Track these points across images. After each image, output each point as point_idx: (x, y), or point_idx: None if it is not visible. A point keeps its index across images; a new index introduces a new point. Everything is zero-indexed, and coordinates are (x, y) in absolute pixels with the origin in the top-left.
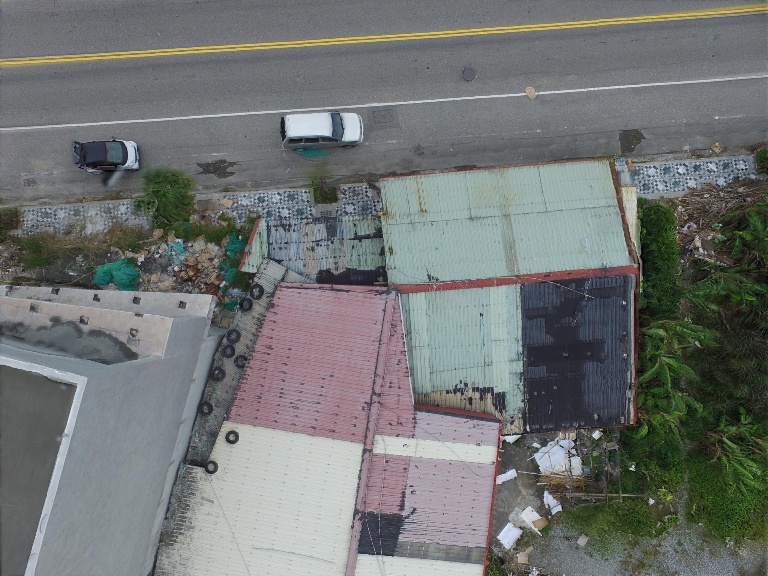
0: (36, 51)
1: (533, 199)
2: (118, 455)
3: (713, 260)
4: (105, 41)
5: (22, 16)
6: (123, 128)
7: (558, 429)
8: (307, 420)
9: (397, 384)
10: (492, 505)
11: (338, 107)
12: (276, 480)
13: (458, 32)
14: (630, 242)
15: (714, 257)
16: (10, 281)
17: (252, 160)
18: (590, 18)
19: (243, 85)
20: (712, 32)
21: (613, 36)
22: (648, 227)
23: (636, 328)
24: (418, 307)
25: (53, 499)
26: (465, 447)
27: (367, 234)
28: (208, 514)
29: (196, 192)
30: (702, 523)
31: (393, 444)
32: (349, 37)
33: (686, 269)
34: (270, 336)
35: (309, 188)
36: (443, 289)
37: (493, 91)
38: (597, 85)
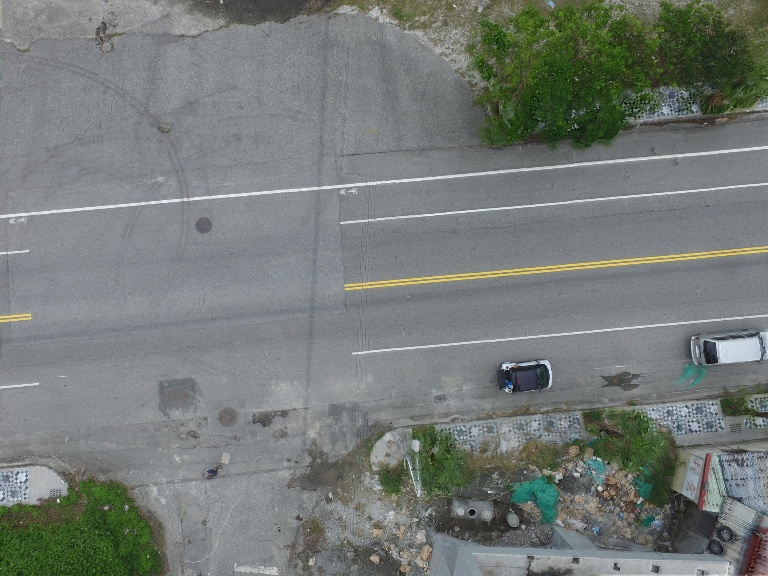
0: (445, 270)
1: None
2: None
3: None
4: (508, 257)
5: (429, 236)
6: (530, 343)
7: None
8: None
9: None
10: None
11: (739, 317)
12: None
13: None
14: None
15: None
16: (428, 499)
17: (656, 372)
18: None
19: (645, 298)
20: None
21: None
22: None
23: None
24: None
25: None
26: None
27: None
28: None
29: (603, 405)
30: None
31: None
32: (747, 247)
33: None
34: None
35: (716, 400)
36: None
37: None
38: None
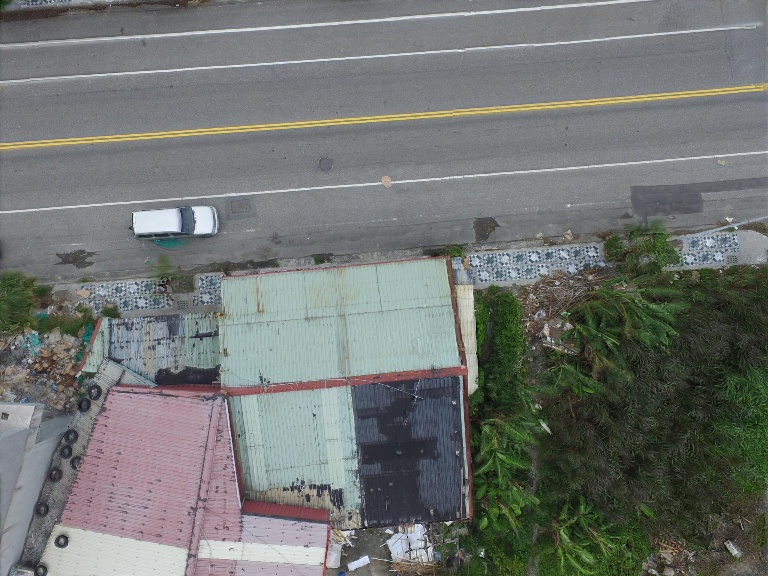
0: None
1: (369, 298)
2: None
3: (561, 348)
4: None
5: None
6: None
7: (396, 524)
8: (135, 525)
9: (223, 489)
10: None
11: (196, 197)
12: None
13: (315, 123)
14: (460, 343)
15: (562, 345)
16: None
17: (111, 250)
18: (444, 108)
19: (102, 176)
20: (565, 121)
21: (467, 126)
22: (495, 317)
23: (466, 427)
24: (251, 408)
25: None
26: (293, 549)
27: (208, 332)
28: None
29: (55, 282)
30: None
31: (219, 548)
32: (207, 128)
33: (537, 356)
34: (101, 440)
35: None
36: (274, 391)
37: (349, 180)
38: (452, 174)
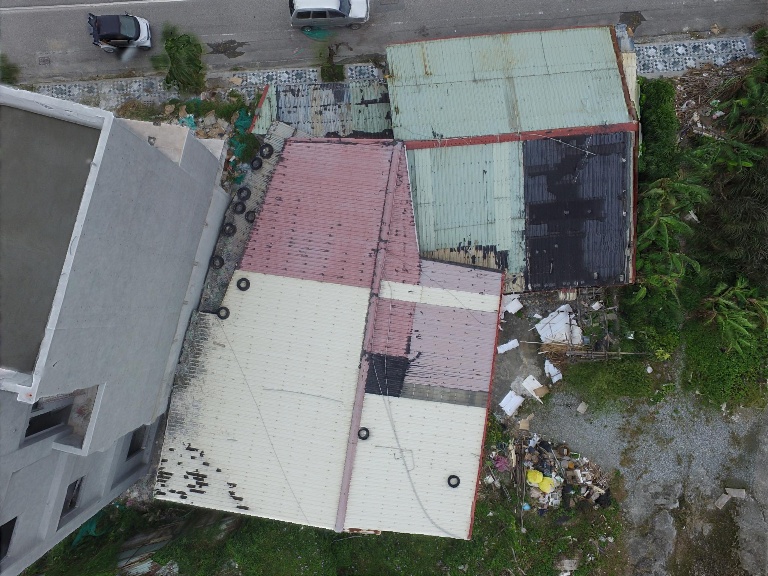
0: None
1: (535, 63)
2: (138, 238)
3: (711, 135)
4: None
5: None
6: (135, 8)
7: (559, 288)
8: (316, 267)
9: (403, 232)
10: None
11: None
12: (286, 324)
13: None
14: (630, 101)
15: (712, 132)
16: None
17: (261, 40)
18: None
19: None
20: None
21: None
22: (648, 101)
23: (635, 185)
24: (423, 163)
25: (82, 224)
26: (469, 295)
27: (373, 99)
28: (220, 358)
29: (206, 71)
30: (699, 389)
31: (399, 290)
32: None
33: (685, 146)
34: (280, 188)
35: (316, 67)
36: (448, 145)
37: None
38: None
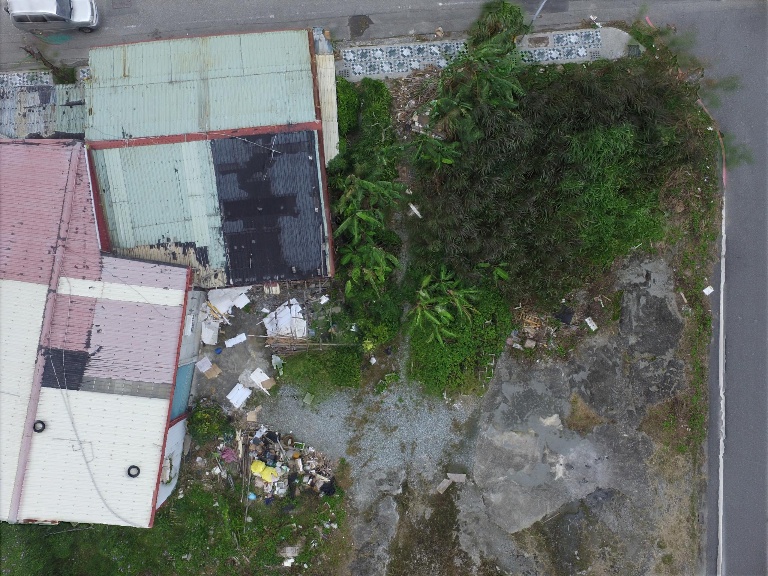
0: None
1: (232, 65)
2: None
3: (428, 133)
4: None
5: None
6: None
7: (260, 282)
8: None
9: (83, 230)
10: (179, 345)
11: None
12: None
13: None
14: (316, 101)
15: (429, 130)
16: None
17: None
18: None
19: None
20: None
21: None
22: None
23: (323, 182)
24: (114, 163)
25: None
26: (152, 290)
27: (78, 101)
28: None
29: None
30: (417, 379)
31: (79, 286)
32: None
33: None
34: None
35: (48, 70)
36: (136, 145)
37: None
38: None
